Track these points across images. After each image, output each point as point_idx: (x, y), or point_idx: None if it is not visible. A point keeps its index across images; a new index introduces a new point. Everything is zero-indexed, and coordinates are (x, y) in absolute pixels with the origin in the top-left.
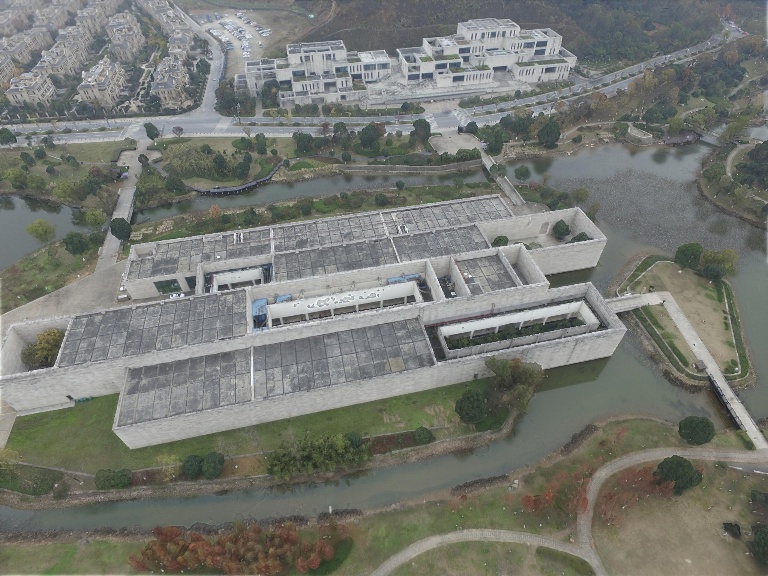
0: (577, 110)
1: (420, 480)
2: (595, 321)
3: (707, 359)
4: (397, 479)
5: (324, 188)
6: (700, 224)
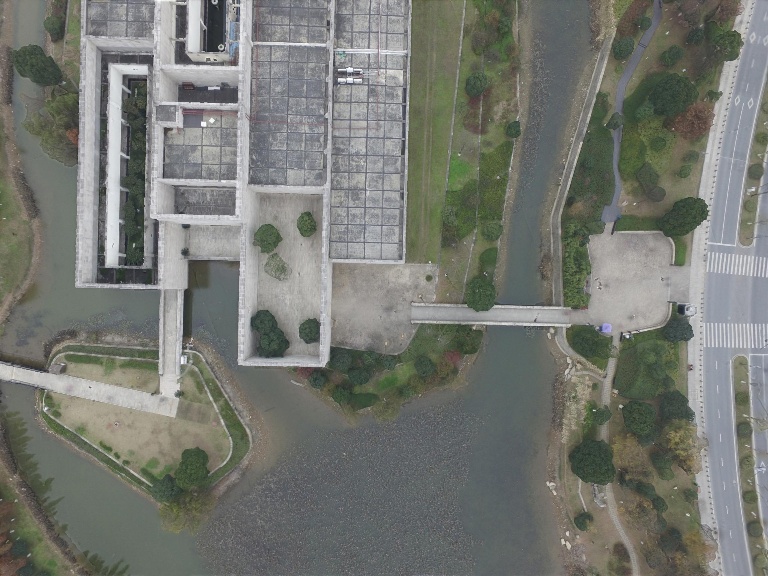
0: (673, 571)
1: (28, 22)
2: (113, 265)
3: (68, 387)
4: (35, 0)
5: (555, 7)
6: (300, 569)
